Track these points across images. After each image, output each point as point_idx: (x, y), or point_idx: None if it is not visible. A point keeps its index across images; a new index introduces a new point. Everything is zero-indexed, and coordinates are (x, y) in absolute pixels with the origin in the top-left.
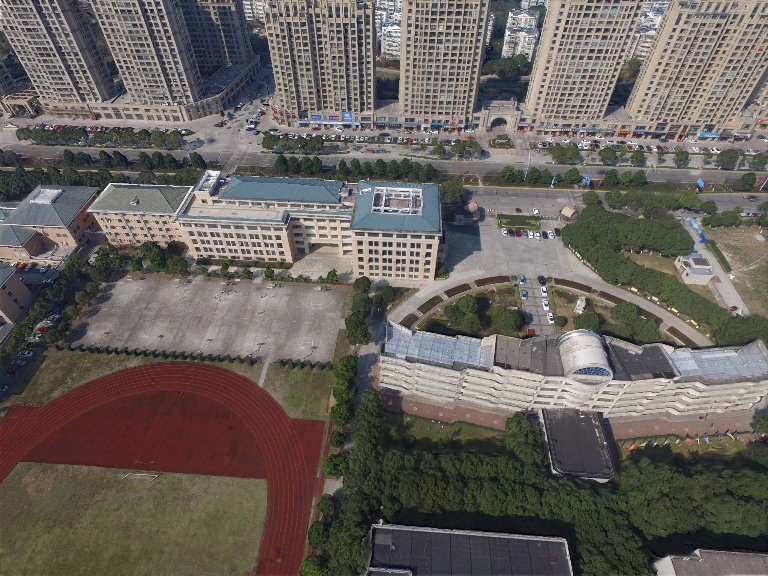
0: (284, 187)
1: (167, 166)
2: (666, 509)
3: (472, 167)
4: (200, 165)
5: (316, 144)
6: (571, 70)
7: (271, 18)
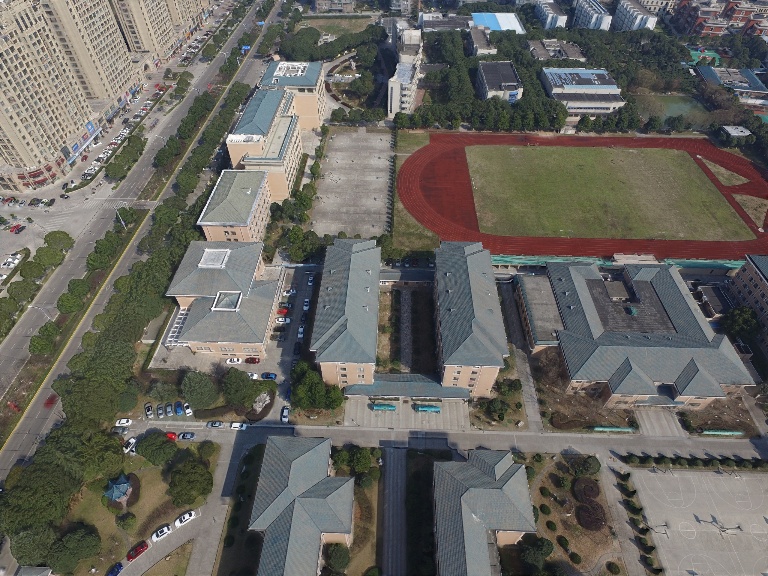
0: (264, 106)
1: (118, 244)
2: (460, 51)
3: (200, 88)
4: (132, 217)
5: (140, 141)
6: (150, 3)
7: None
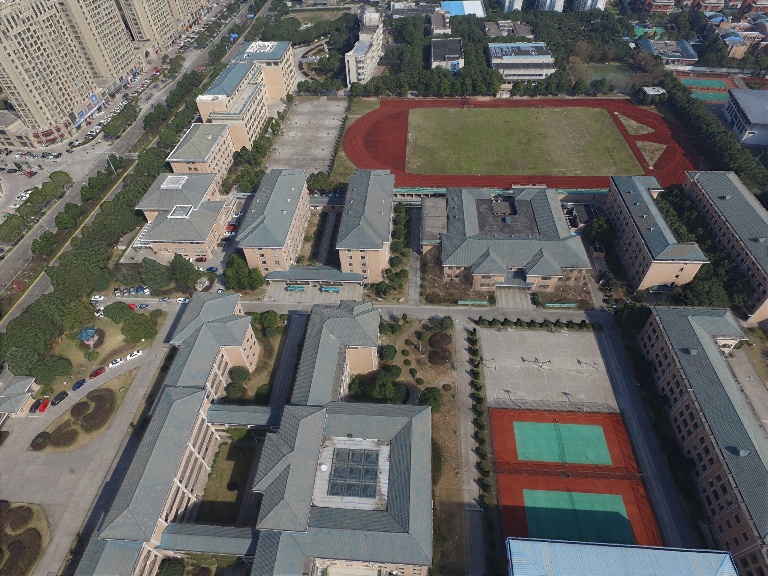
0: (232, 74)
1: (108, 182)
2: (419, 32)
3: None
4: None
5: (133, 108)
6: None
7: (2, 37)
